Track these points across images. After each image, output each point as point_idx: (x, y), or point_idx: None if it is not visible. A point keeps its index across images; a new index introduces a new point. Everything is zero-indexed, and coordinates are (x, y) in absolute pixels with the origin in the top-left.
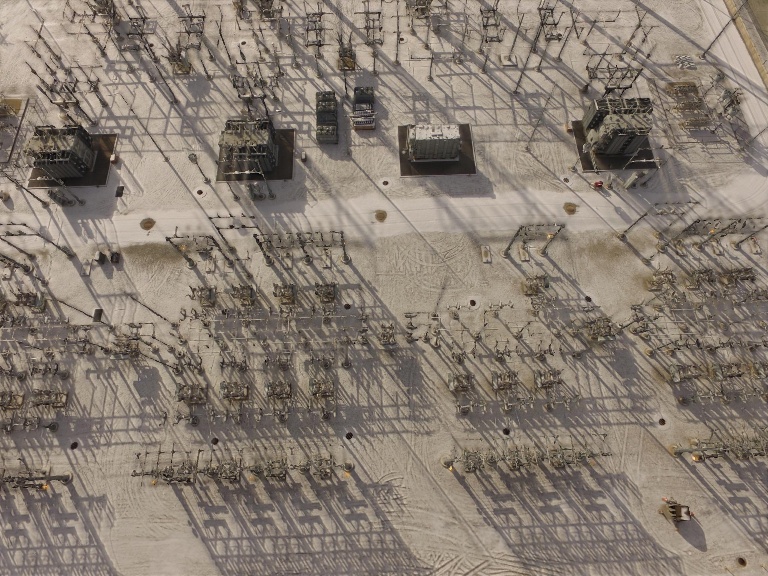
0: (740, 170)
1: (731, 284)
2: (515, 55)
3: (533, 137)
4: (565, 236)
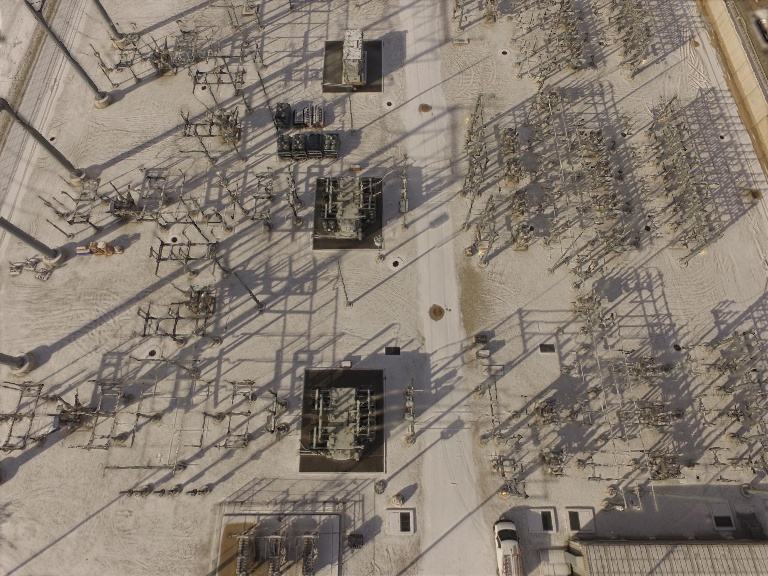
0: None
1: None
2: (245, 5)
3: (344, 2)
4: None
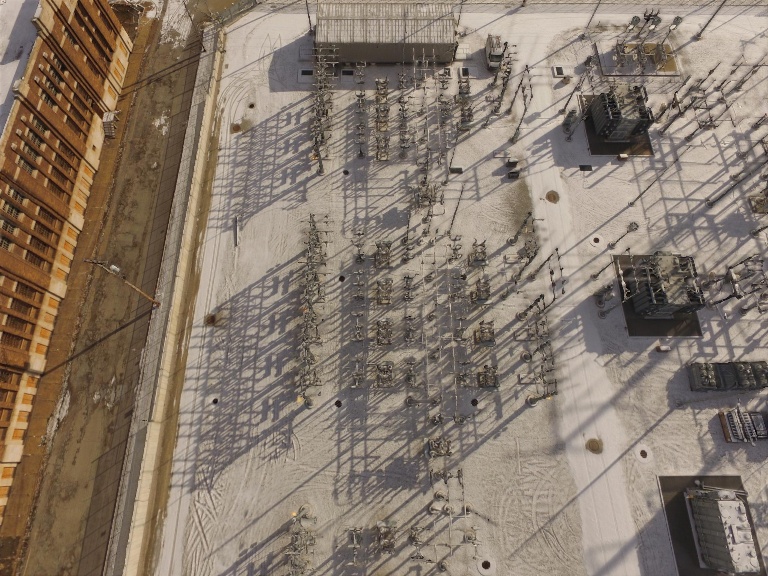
0: None
1: None
2: None
3: None
4: None
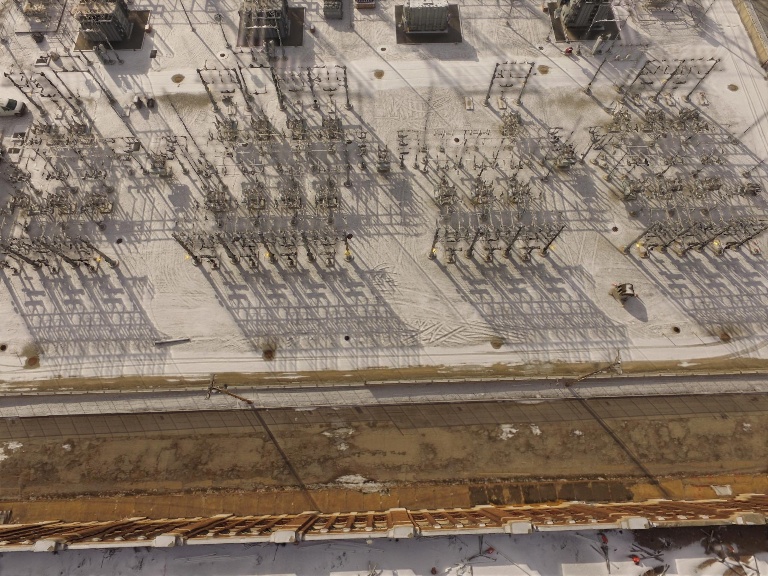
0: (694, 42)
1: (680, 127)
2: None
3: (513, 15)
4: (538, 91)
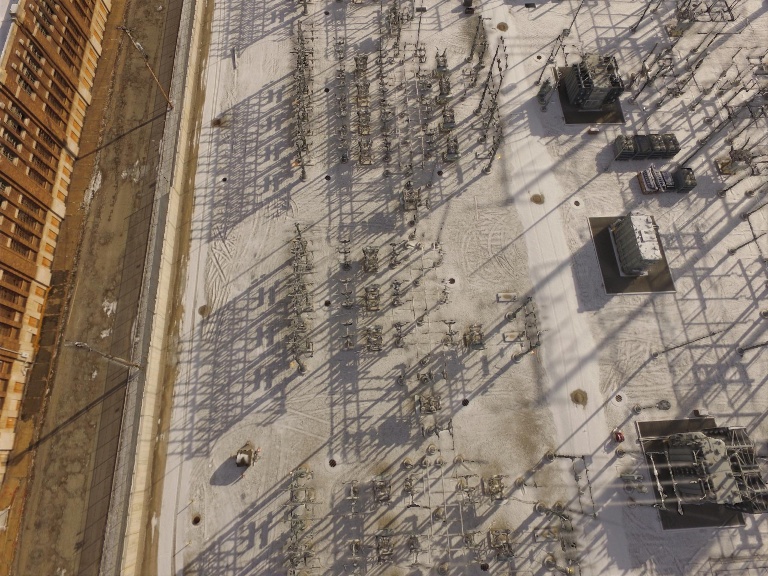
0: None
1: None
2: None
3: (675, 365)
4: (541, 387)
